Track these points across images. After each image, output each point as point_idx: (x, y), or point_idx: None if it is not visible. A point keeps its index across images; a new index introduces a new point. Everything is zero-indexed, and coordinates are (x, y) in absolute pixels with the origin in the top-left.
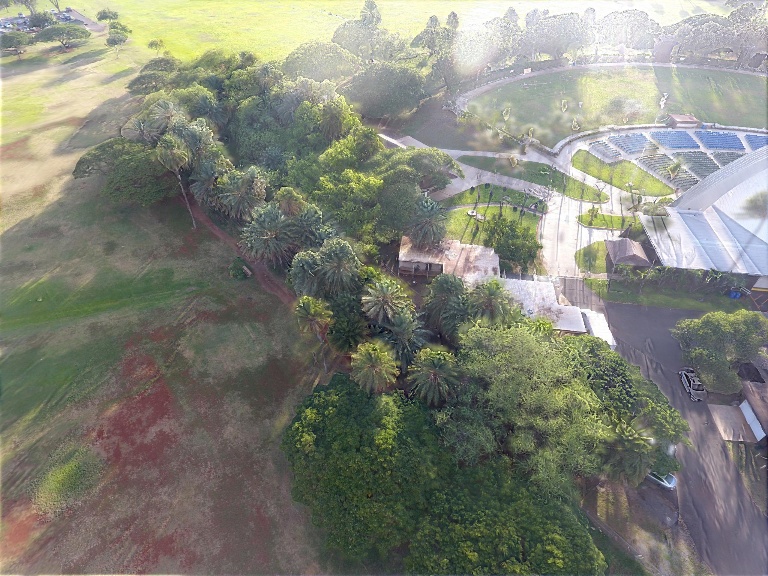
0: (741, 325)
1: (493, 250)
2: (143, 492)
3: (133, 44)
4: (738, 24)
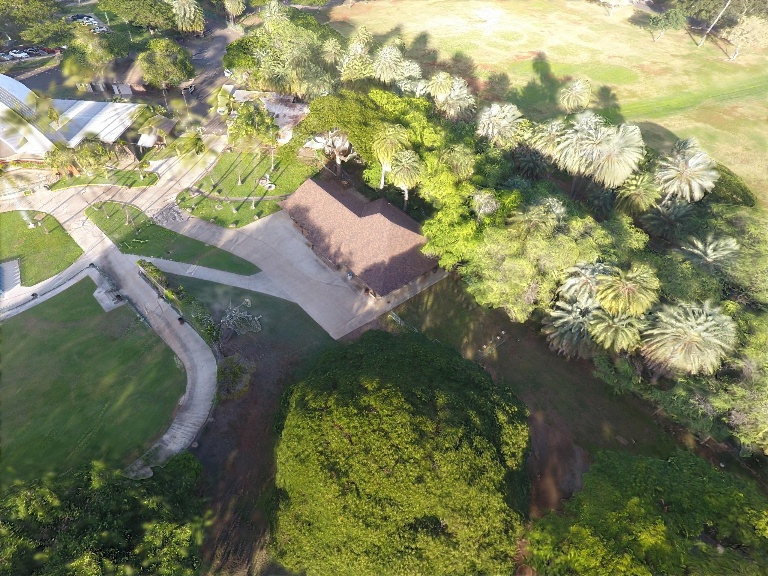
0: (161, 56)
1: None
2: (450, 71)
3: None
4: None
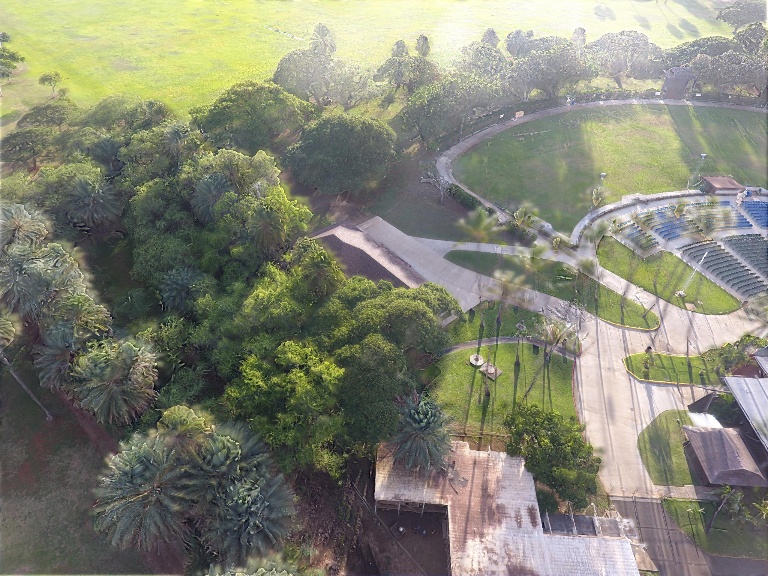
0: None
1: (522, 463)
2: None
3: (26, 75)
4: (760, 53)
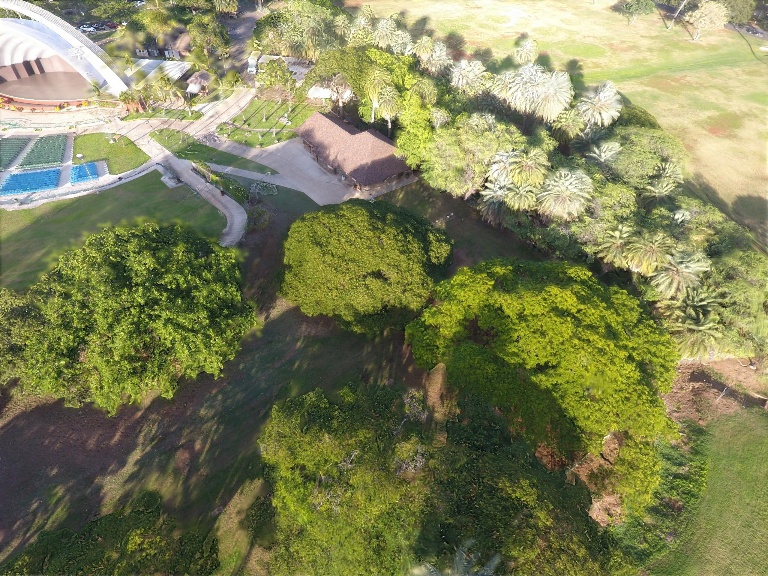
0: None
1: None
2: None
3: None
4: None
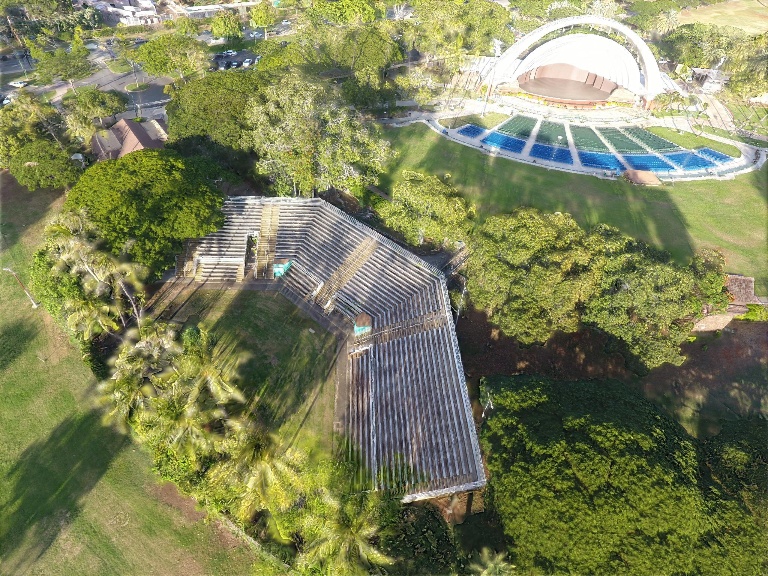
0: None
1: None
2: None
3: None
4: None
